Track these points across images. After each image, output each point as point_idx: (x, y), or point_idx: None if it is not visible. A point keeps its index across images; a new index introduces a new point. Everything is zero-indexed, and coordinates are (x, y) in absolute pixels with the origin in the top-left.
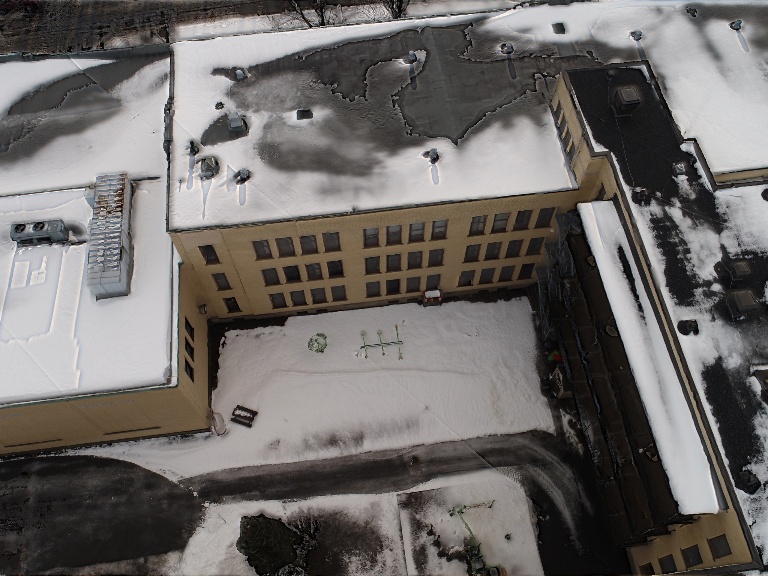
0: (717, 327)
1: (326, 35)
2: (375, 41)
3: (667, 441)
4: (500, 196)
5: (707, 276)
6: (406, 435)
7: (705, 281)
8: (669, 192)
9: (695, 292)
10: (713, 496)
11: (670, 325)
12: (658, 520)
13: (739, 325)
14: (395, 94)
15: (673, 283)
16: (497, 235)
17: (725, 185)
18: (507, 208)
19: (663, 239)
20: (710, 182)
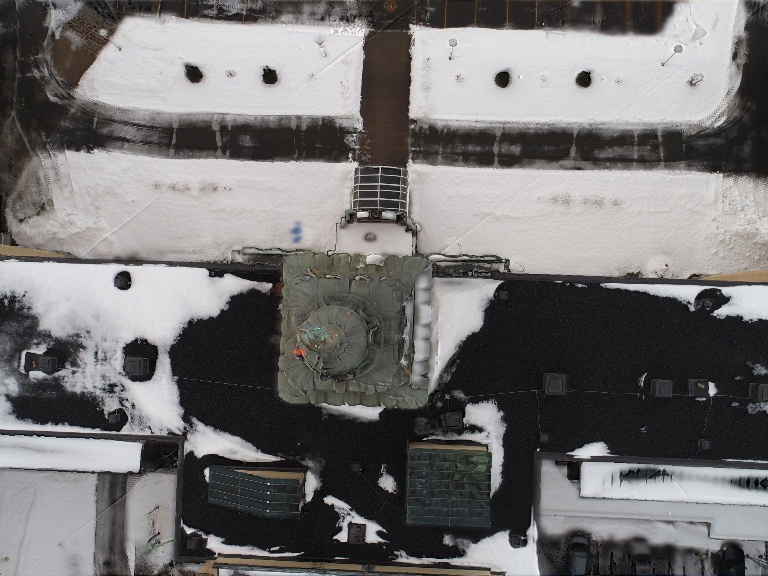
0: None
1: None
2: None
3: (77, 462)
4: None
5: None
6: (83, 568)
7: None
8: None
9: None
10: (127, 445)
11: None
12: (156, 457)
13: None
14: None
15: None
16: None
17: None
18: None
19: None
20: None
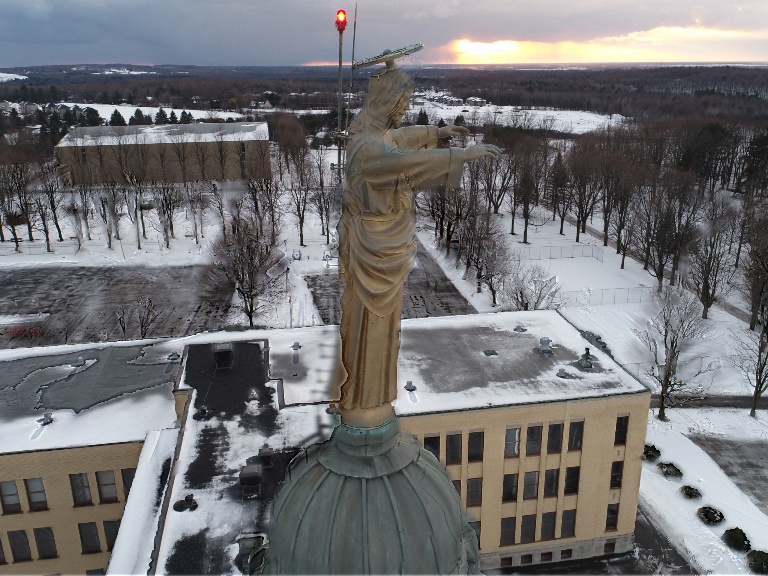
0: (220, 504)
1: (12, 353)
2: (55, 356)
3: None
4: (92, 444)
5: (235, 466)
6: None
7: (230, 470)
8: (234, 412)
9: (213, 478)
10: None
11: (165, 503)
12: None
13: (246, 502)
14: (45, 384)
15: (194, 472)
16: (110, 507)
17: (291, 404)
18: (105, 462)
19: (206, 442)
20: (279, 404)
